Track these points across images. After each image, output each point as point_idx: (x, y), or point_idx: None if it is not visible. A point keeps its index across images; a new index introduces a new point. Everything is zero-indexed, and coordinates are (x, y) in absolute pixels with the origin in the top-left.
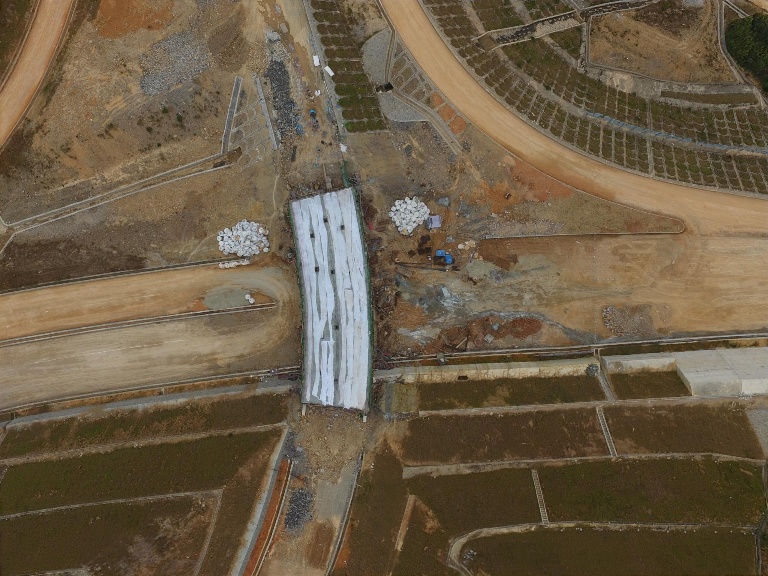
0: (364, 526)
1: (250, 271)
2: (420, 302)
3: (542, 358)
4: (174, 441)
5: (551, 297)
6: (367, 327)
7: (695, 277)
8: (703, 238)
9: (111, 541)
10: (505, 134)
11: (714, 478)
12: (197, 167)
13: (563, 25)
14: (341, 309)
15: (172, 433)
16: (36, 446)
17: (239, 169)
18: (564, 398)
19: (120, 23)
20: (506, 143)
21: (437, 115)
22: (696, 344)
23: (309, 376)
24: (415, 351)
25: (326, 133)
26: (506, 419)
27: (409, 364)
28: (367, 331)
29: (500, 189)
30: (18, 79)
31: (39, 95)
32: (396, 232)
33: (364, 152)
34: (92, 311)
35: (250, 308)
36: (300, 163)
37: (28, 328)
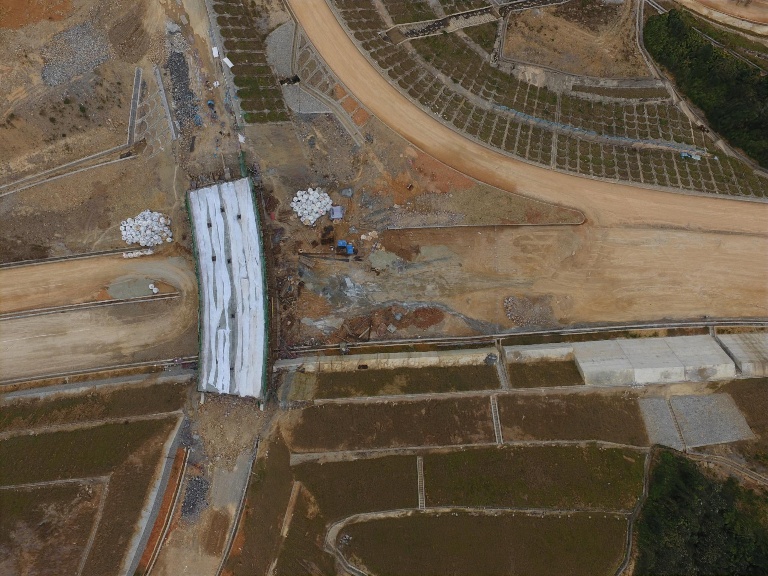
0: (257, 513)
1: (154, 261)
2: (323, 292)
3: (444, 348)
4: (70, 429)
5: (453, 287)
6: (262, 316)
7: (596, 268)
8: (603, 229)
9: None
10: (408, 126)
11: (596, 465)
12: (104, 158)
13: (479, 20)
14: (237, 298)
15: (69, 421)
16: None
17: (144, 160)
18: (459, 387)
19: (21, 14)
20: (408, 135)
21: (340, 107)
22: (596, 334)
23: (206, 364)
24: (318, 341)
25: (224, 124)
26: (400, 407)
27: (312, 354)
28: (262, 320)
29: (403, 180)
30: None
31: None
32: (299, 222)
33: (263, 143)
34: None
35: (154, 298)
36: (199, 153)
37: None
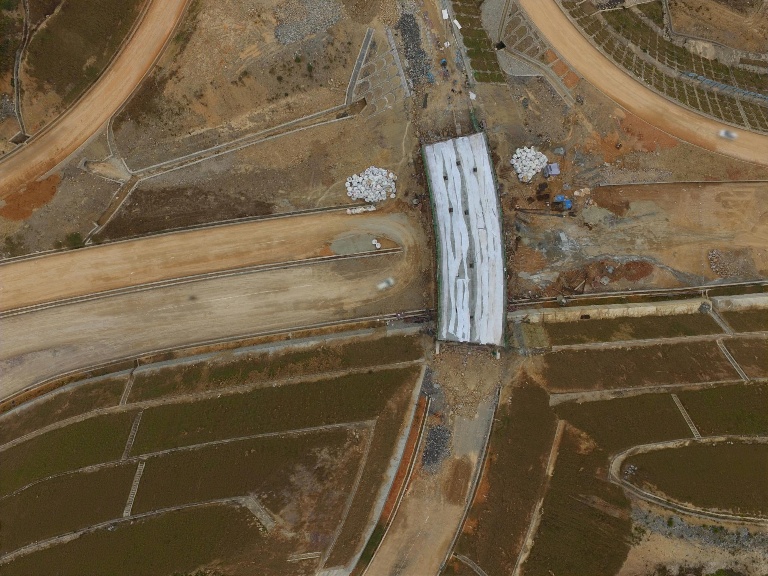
0: (505, 459)
1: (376, 217)
2: (539, 247)
3: (655, 299)
4: (313, 380)
5: (661, 241)
6: (501, 265)
7: None
8: None
9: (273, 470)
10: (614, 89)
11: None
12: (321, 118)
13: None
14: (475, 248)
15: (311, 372)
16: (170, 389)
17: (363, 119)
18: (686, 332)
19: None
20: (616, 97)
21: (551, 70)
22: None
23: (445, 314)
24: (535, 294)
25: (456, 82)
26: (635, 352)
27: (530, 307)
28: (501, 269)
29: (611, 140)
30: (148, 29)
31: (170, 44)
32: (516, 179)
33: (490, 101)
34: (219, 257)
35: (377, 253)
36: (431, 110)
37: (153, 274)
